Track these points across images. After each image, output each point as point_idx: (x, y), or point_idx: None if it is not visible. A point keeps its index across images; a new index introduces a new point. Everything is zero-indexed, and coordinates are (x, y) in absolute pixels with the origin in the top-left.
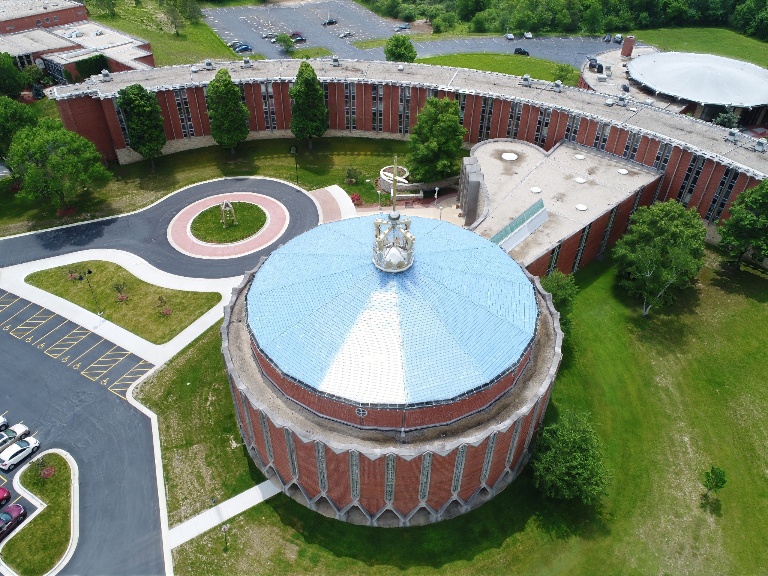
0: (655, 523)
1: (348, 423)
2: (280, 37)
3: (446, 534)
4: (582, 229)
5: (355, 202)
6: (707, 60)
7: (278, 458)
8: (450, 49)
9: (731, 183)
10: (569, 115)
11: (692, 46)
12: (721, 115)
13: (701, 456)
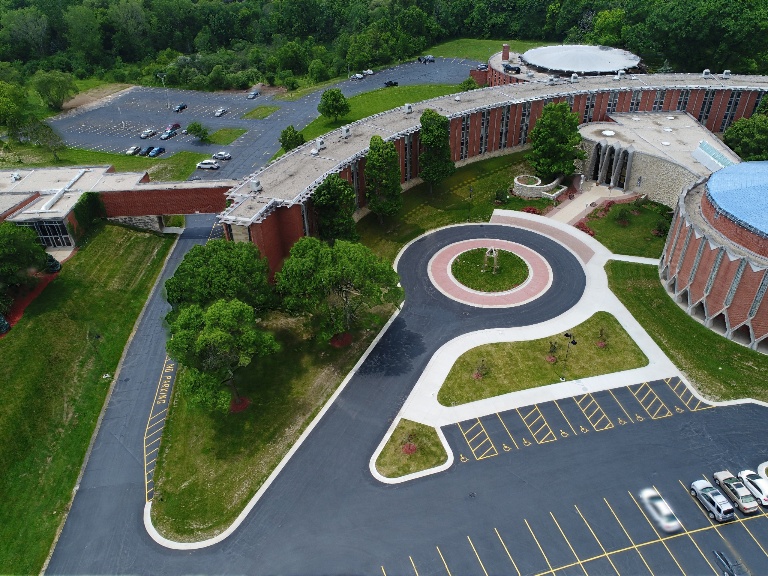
0: None
1: None
2: (193, 127)
3: None
4: None
5: (538, 212)
6: (553, 50)
7: None
8: None
9: (736, 101)
10: (610, 93)
11: (477, 52)
12: None
13: None
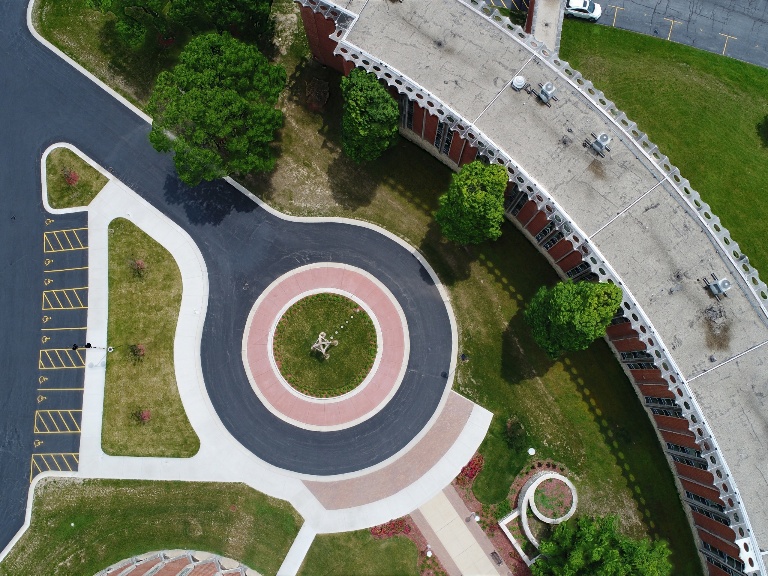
0: None
1: None
2: None
3: None
4: None
5: (459, 477)
6: None
7: None
8: None
9: None
10: None
11: None
12: None
13: None
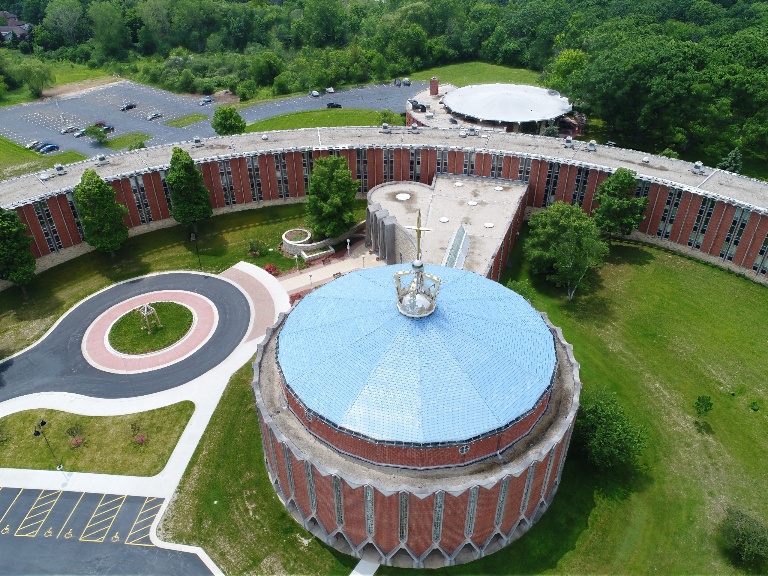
0: (678, 457)
1: (449, 465)
2: (89, 129)
3: (543, 536)
4: (501, 242)
5: (273, 272)
6: (497, 88)
7: (381, 530)
8: (266, 113)
9: (585, 179)
10: (437, 151)
11: (465, 79)
12: (545, 129)
13: (675, 394)
